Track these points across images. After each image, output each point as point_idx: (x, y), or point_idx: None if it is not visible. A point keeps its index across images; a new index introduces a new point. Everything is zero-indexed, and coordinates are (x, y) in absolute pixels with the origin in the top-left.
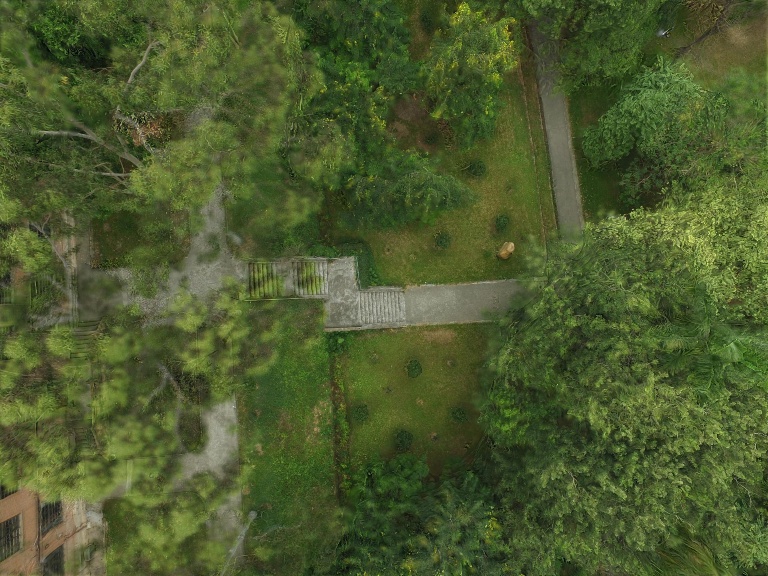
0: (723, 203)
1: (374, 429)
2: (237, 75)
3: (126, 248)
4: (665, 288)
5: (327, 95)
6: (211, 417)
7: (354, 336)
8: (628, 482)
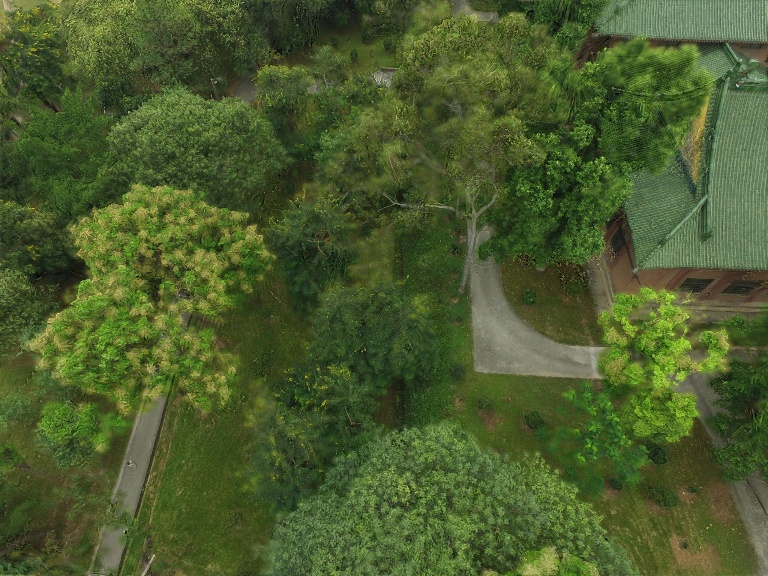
0: None
1: (382, 45)
2: None
3: None
4: None
5: None
6: None
7: None
8: None
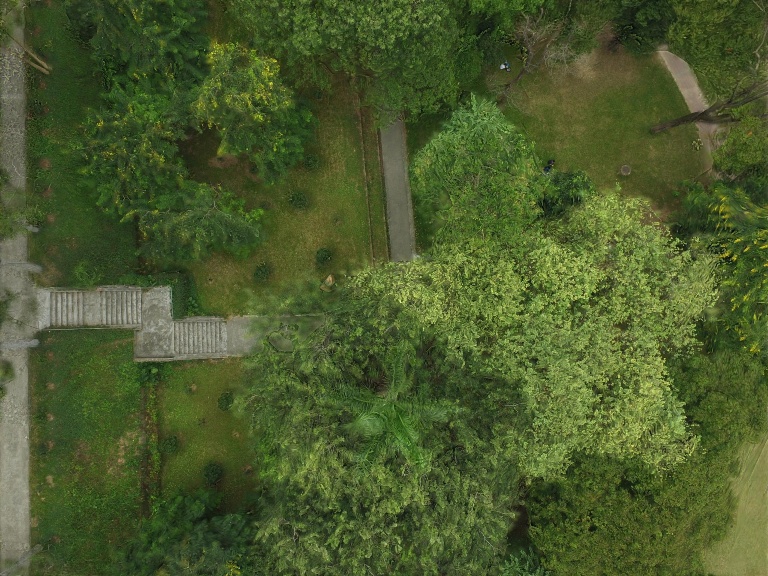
0: (472, 255)
1: (188, 461)
2: (47, 101)
3: None
4: (374, 345)
5: (109, 128)
6: (4, 447)
7: (172, 366)
8: (334, 541)
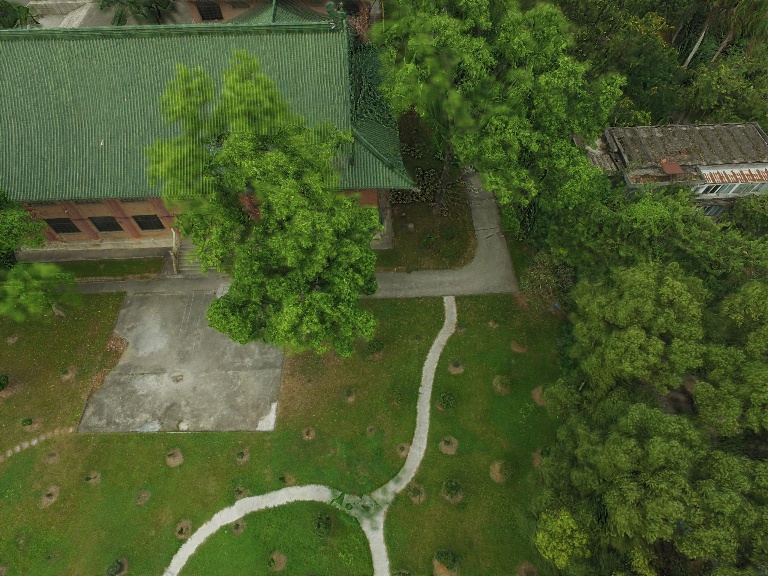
0: None
1: None
2: None
3: None
4: None
5: None
6: None
7: None
8: None
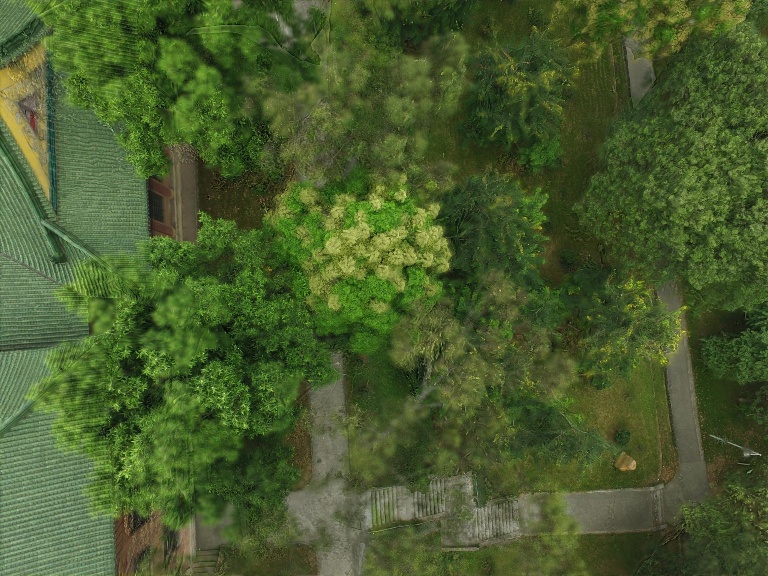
0: None
1: None
2: None
3: (246, 475)
4: None
5: None
6: None
7: None
8: None
